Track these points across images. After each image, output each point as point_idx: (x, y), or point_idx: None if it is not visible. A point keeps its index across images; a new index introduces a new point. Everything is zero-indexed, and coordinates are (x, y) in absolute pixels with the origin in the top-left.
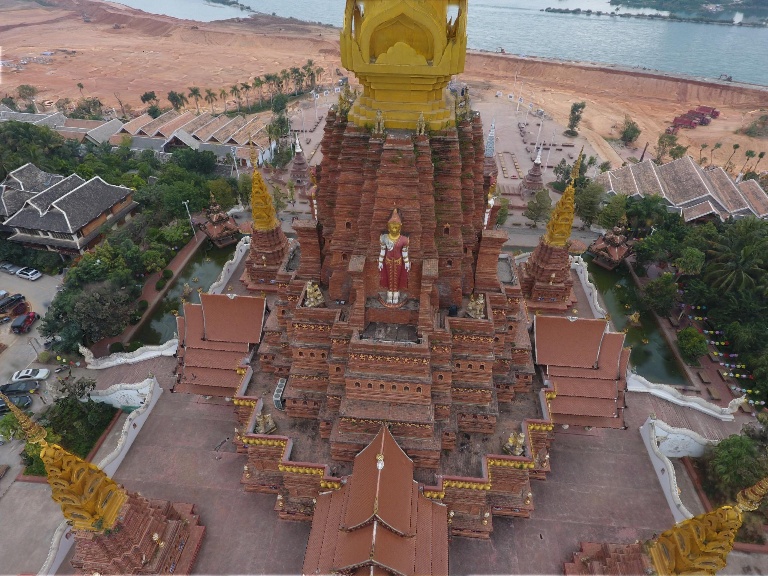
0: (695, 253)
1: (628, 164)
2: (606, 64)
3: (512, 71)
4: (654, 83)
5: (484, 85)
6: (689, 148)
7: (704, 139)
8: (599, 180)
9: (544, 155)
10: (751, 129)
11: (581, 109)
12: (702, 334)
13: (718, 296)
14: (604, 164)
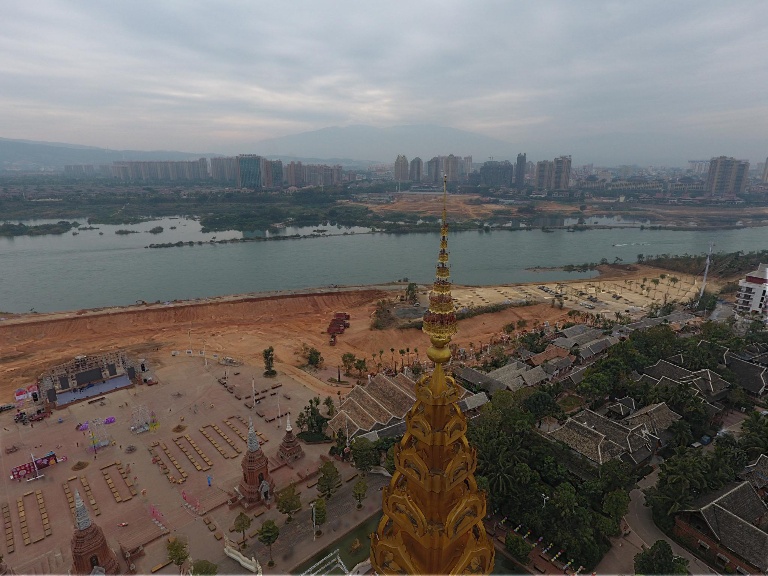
0: (482, 480)
1: (333, 387)
2: (246, 294)
3: (165, 321)
4: (291, 302)
5: (150, 346)
6: (366, 360)
7: (357, 340)
8: (341, 421)
9: (265, 405)
10: (377, 324)
11: (271, 353)
12: (509, 530)
13: (502, 498)
14: (327, 400)
